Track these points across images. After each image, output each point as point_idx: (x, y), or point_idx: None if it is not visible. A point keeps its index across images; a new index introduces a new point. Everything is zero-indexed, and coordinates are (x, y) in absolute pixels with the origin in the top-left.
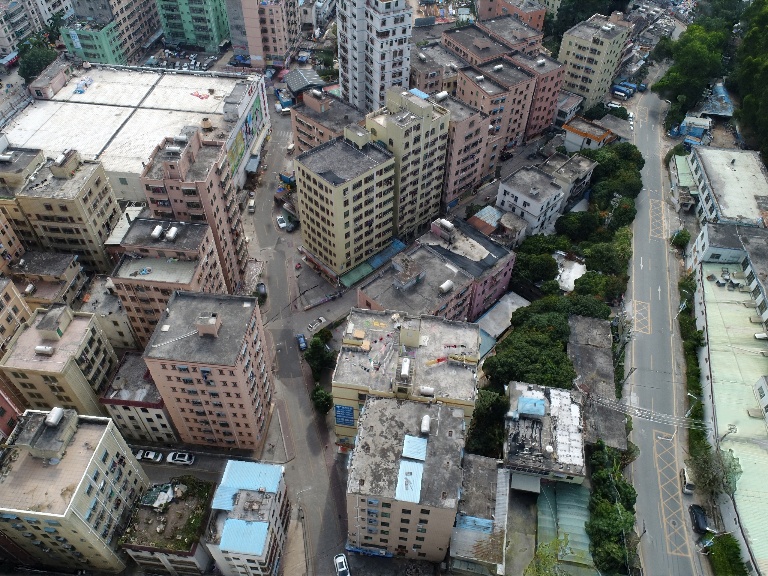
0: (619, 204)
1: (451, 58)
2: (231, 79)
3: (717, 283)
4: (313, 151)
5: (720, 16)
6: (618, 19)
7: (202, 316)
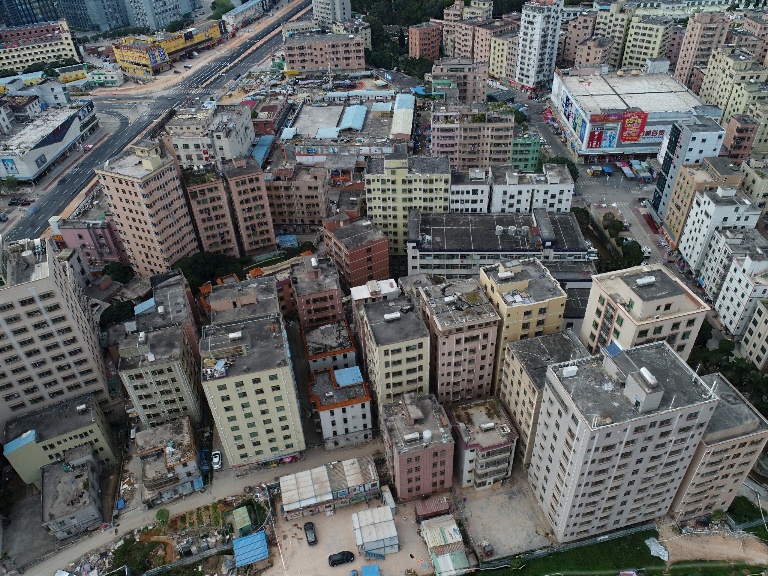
0: None
1: (507, 35)
2: (562, 80)
3: None
4: (653, 26)
5: (413, 2)
6: (461, 2)
7: (767, 15)
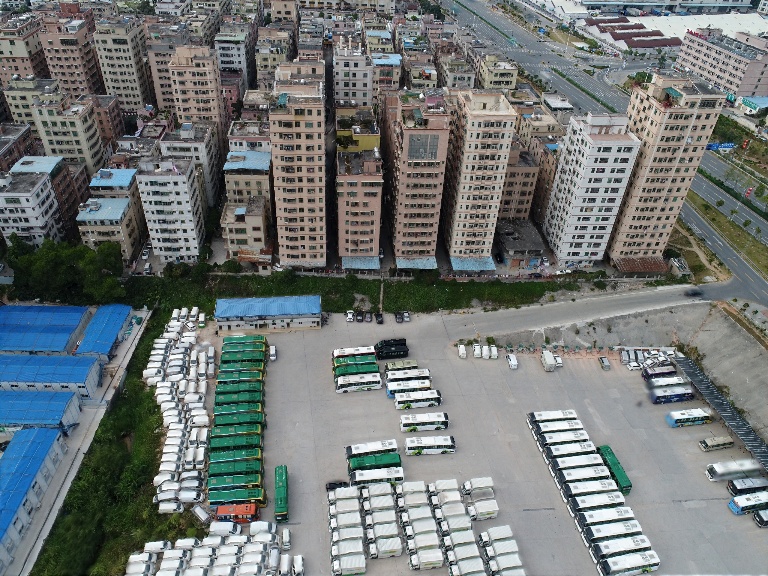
0: (1, 8)
1: None
2: None
3: (53, 0)
4: None
5: None
6: None
7: (48, 4)
